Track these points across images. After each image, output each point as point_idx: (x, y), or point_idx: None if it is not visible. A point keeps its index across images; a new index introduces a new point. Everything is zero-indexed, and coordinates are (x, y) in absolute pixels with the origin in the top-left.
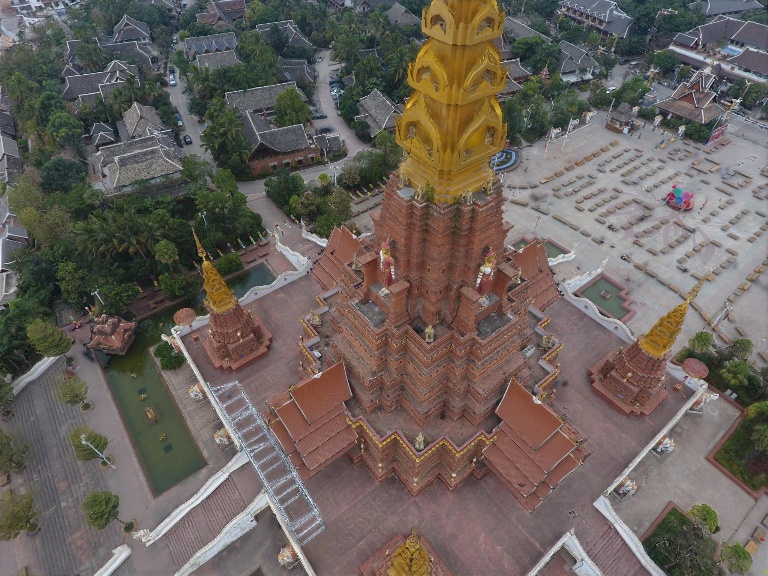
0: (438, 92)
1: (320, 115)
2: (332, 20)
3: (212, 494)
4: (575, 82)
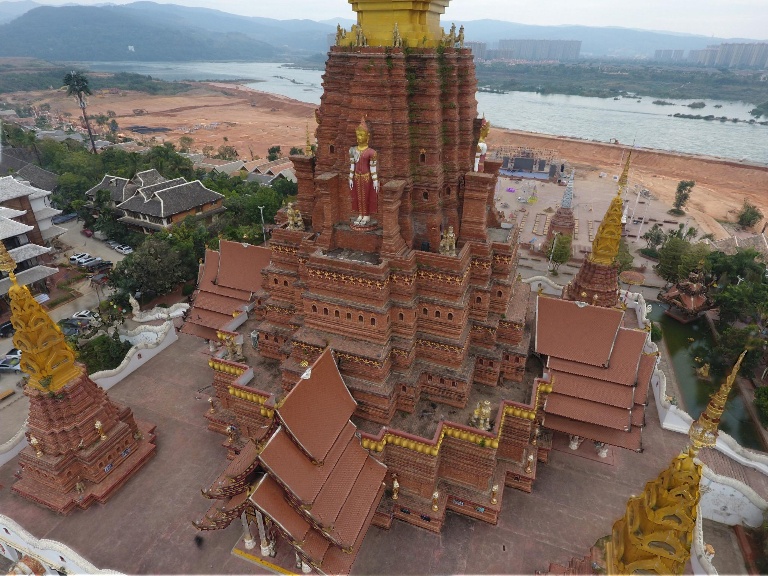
0: None
1: None
2: None
3: None
4: None
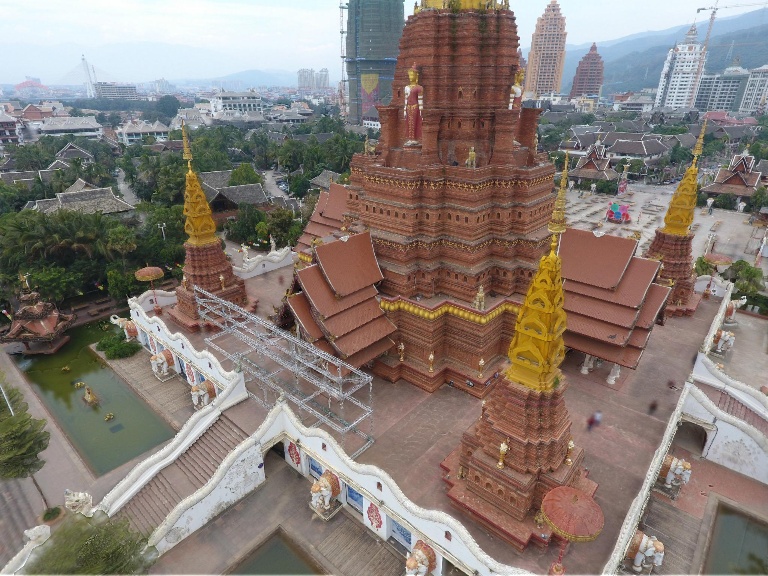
0: None
1: (272, 196)
2: (274, 142)
3: (195, 444)
4: None
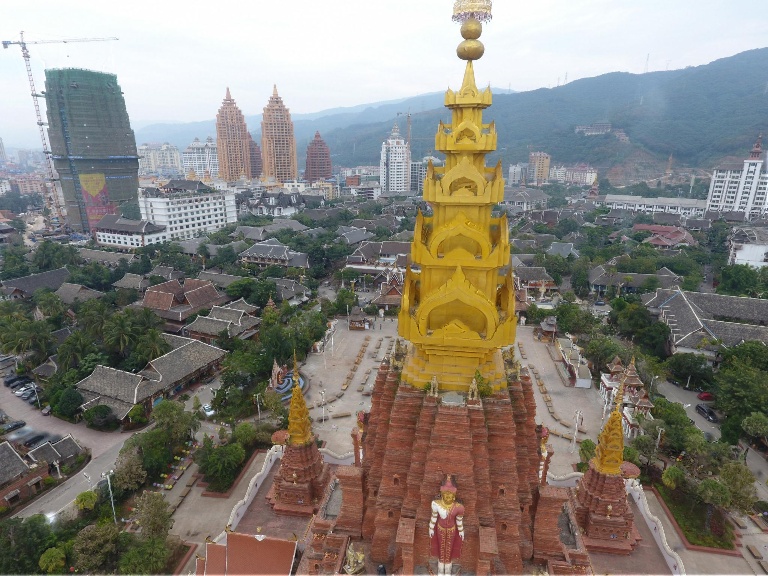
0: (477, 259)
1: (13, 425)
2: None
3: None
4: (298, 305)
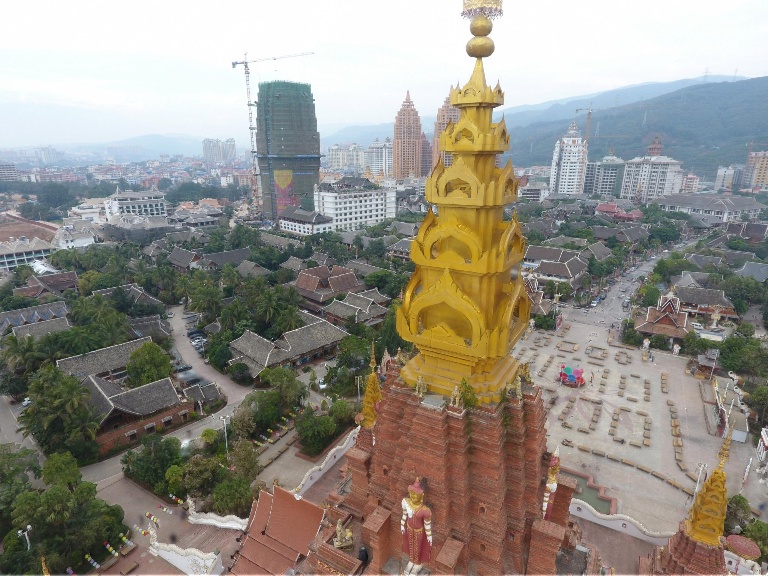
0: (468, 263)
1: (183, 367)
2: (183, 278)
3: None
4: None
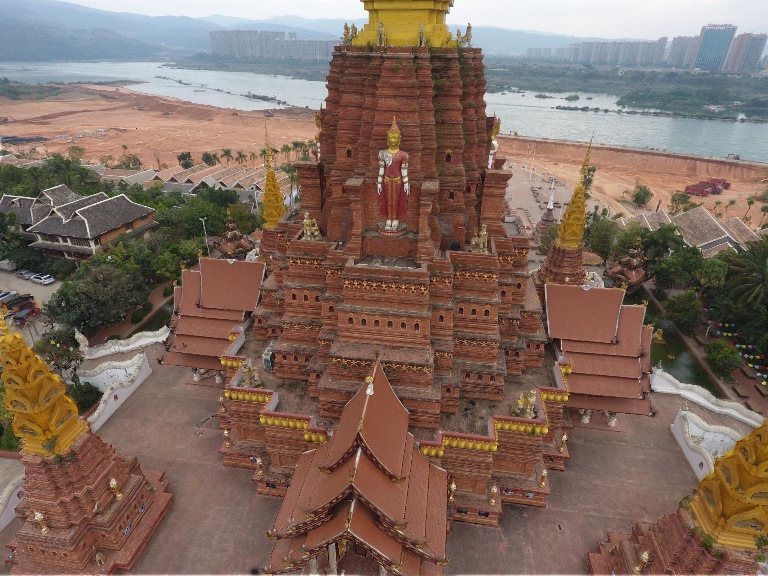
0: None
1: None
2: None
3: None
4: None
